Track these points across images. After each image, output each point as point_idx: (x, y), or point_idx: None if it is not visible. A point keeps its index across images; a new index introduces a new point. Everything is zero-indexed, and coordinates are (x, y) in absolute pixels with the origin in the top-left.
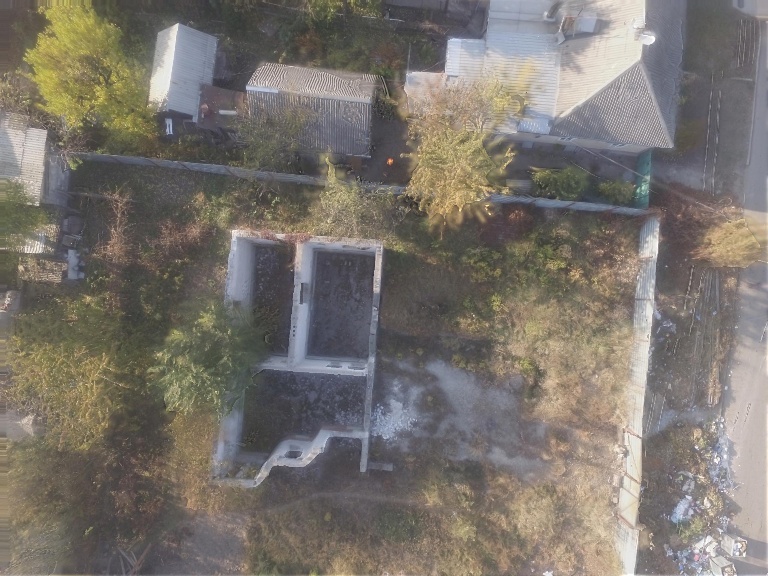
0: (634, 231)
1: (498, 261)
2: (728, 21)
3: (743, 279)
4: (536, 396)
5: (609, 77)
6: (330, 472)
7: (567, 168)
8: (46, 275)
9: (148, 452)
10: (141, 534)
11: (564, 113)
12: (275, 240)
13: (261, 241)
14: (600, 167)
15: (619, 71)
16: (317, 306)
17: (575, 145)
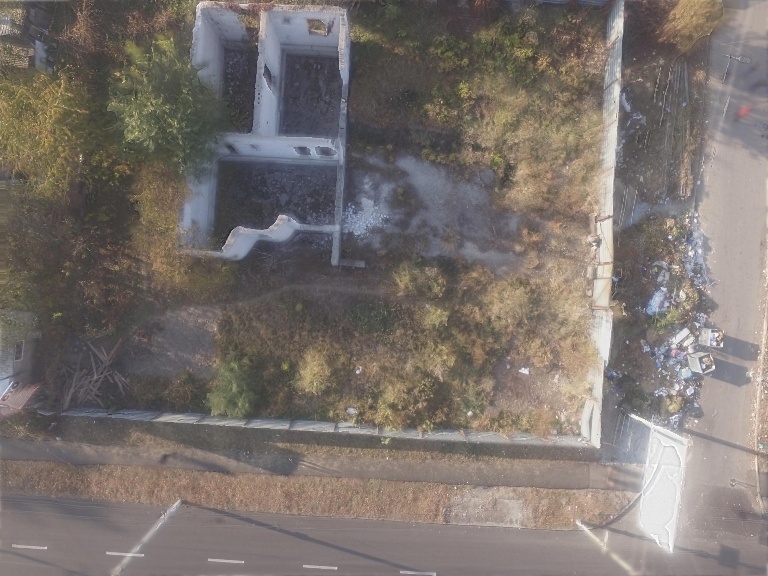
0: (601, 22)
1: (465, 52)
2: None
3: (712, 74)
4: (507, 187)
5: None
6: (302, 270)
7: None
8: (13, 60)
9: (117, 245)
10: (110, 324)
11: None
12: (239, 10)
13: (227, 27)
14: None
15: None
16: (287, 109)
17: None
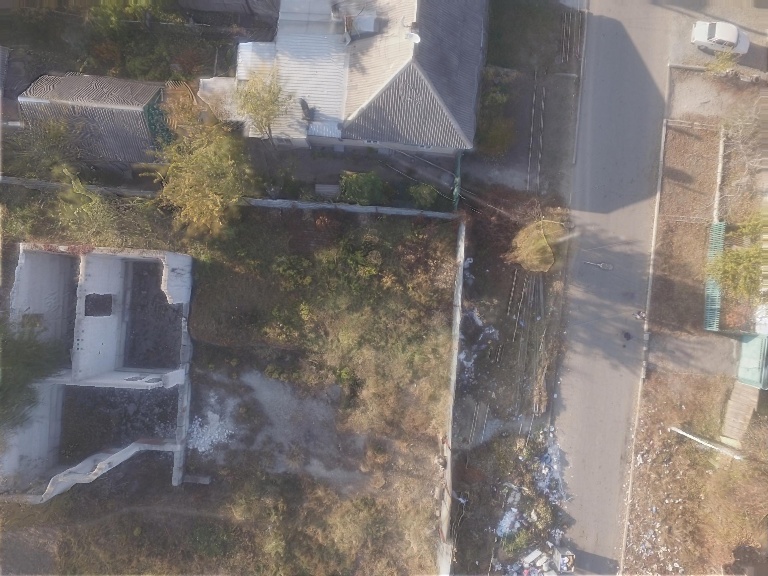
0: (450, 235)
1: (309, 268)
2: (551, 15)
3: (571, 282)
4: (352, 406)
5: (386, 77)
6: (147, 486)
7: (371, 172)
8: None
9: None
10: None
11: (351, 116)
12: (59, 252)
13: (60, 253)
14: (417, 169)
15: (395, 71)
16: (135, 317)
17: (387, 147)
